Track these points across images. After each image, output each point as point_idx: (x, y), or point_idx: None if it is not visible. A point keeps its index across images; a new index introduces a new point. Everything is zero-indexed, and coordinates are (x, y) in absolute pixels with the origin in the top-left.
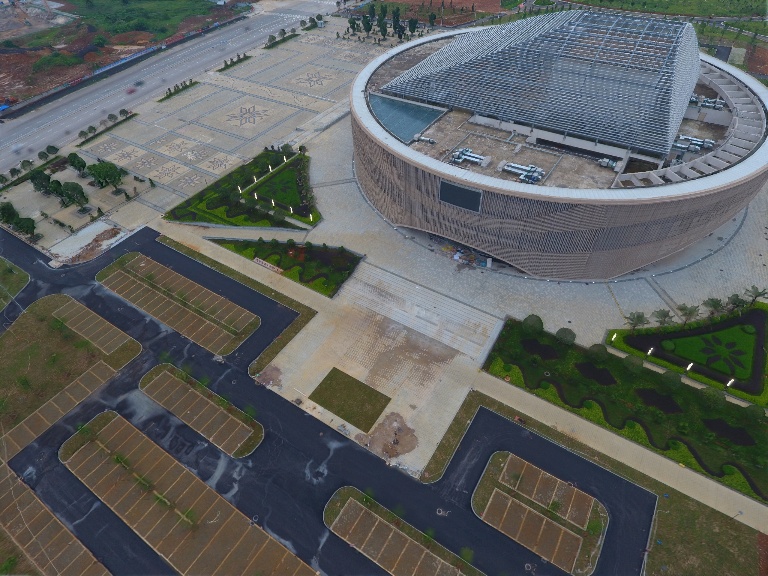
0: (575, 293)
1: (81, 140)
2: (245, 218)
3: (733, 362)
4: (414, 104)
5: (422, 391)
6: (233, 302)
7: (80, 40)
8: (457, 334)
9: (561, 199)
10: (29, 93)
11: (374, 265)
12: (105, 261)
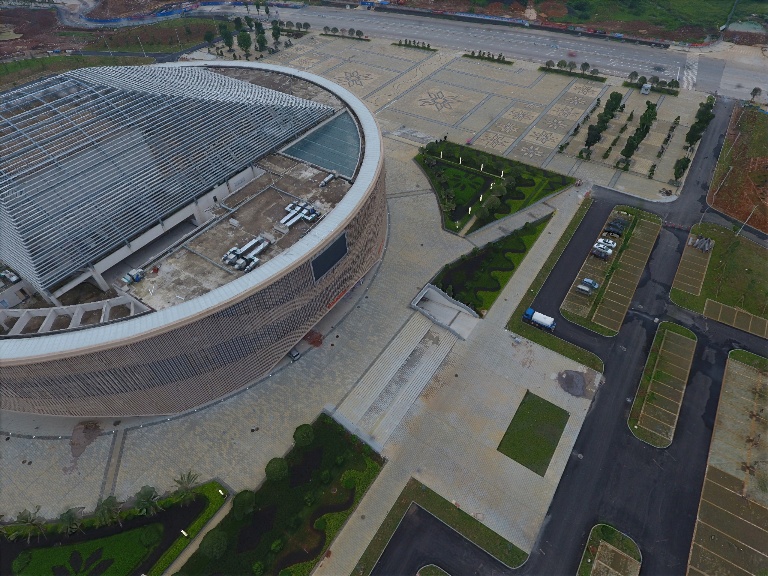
0: None
1: None
2: None
3: None
4: None
5: None
6: None
7: None
8: None
9: None
10: (418, 5)
11: None
12: None
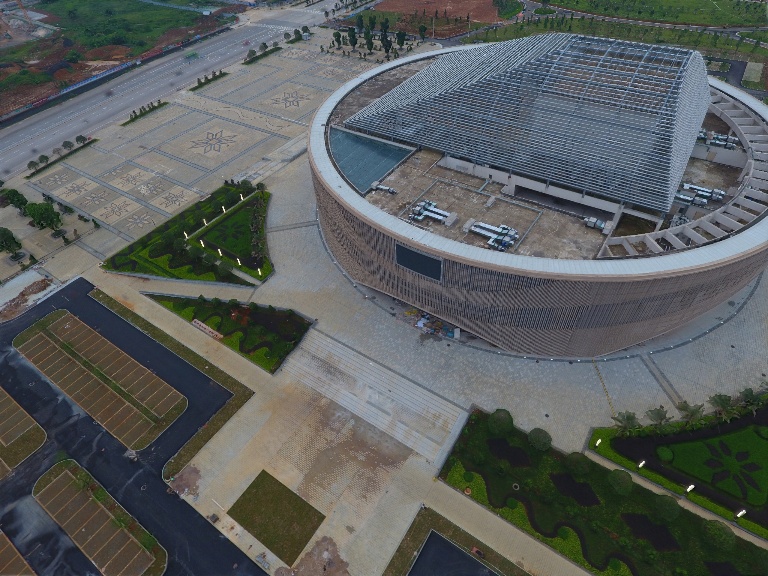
0: (556, 375)
1: (31, 171)
2: (188, 270)
3: (745, 481)
4: (379, 141)
5: (363, 507)
6: (160, 377)
7: (54, 55)
8: (412, 428)
9: (535, 273)
10: None
11: (325, 333)
12: (27, 321)
